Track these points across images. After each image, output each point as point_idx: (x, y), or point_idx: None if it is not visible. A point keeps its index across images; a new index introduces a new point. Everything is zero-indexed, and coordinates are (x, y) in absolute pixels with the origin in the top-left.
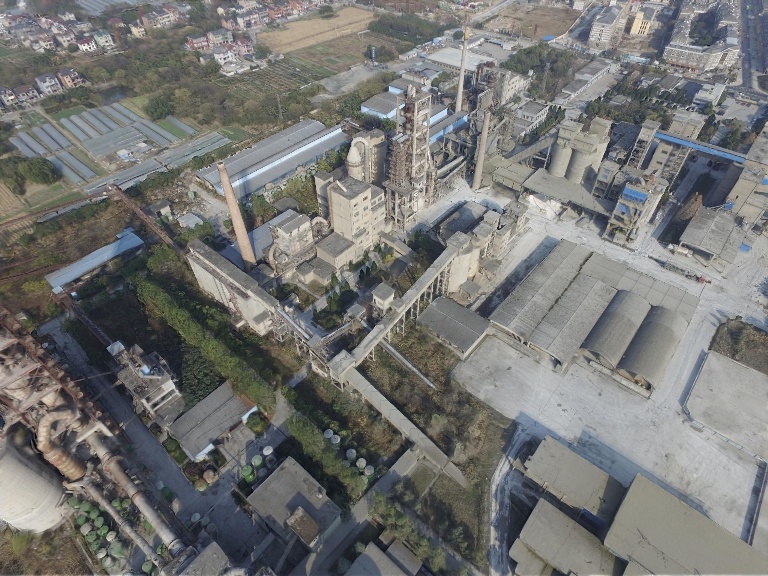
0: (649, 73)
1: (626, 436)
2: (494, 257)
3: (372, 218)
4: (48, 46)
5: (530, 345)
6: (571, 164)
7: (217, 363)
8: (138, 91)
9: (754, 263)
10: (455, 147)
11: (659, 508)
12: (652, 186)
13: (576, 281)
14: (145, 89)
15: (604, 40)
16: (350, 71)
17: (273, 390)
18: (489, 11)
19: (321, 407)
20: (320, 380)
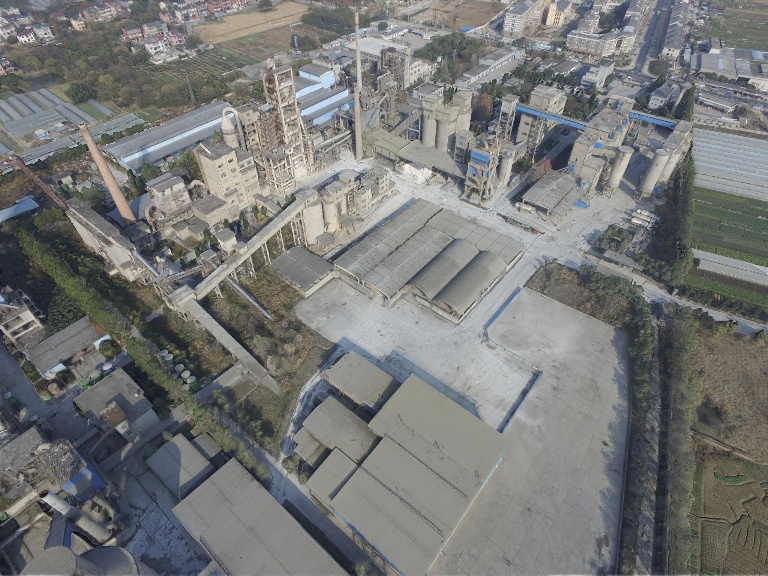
0: (549, 59)
1: (428, 354)
2: (359, 216)
3: (242, 180)
4: None
5: (365, 284)
6: (437, 134)
7: (76, 299)
8: (67, 78)
9: (589, 218)
10: (346, 123)
11: (421, 398)
12: (495, 149)
13: (419, 232)
14: (73, 76)
15: (516, 30)
16: (273, 59)
17: (131, 324)
18: (421, 5)
19: (169, 336)
20: (171, 314)
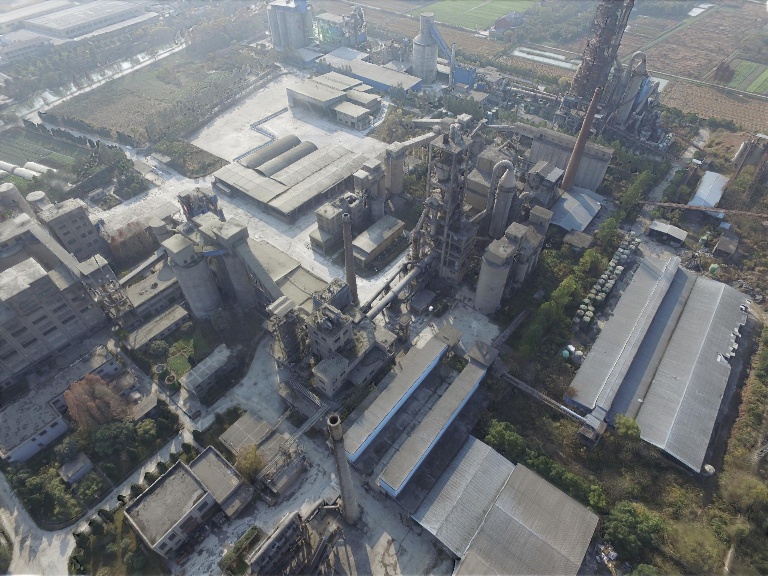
0: None
1: (312, 133)
2: None
3: None
4: None
5: None
6: None
7: None
8: None
9: None
10: None
11: (321, 96)
12: None
13: (298, 181)
14: None
15: None
16: None
17: None
18: None
19: None
20: None
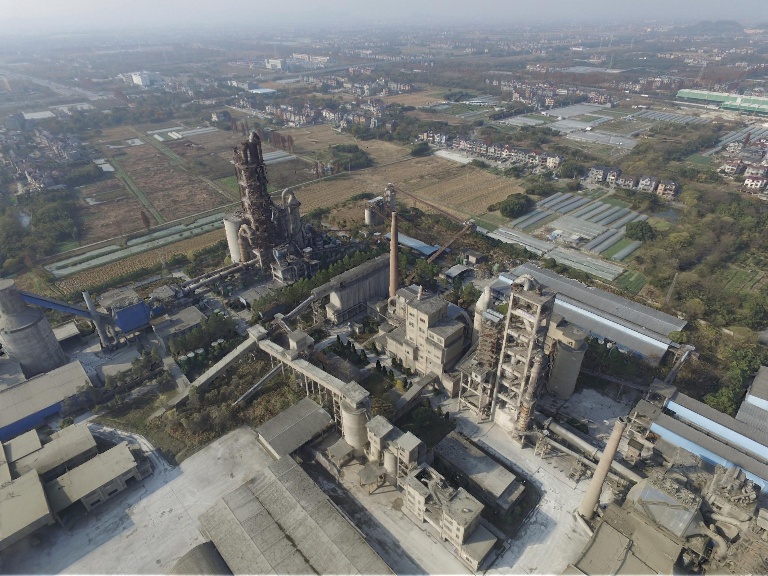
0: None
1: (102, 568)
2: None
3: None
4: (729, 170)
5: None
6: None
7: None
8: None
9: None
10: None
11: (15, 518)
12: None
13: None
14: (683, 221)
15: None
16: None
17: None
18: None
19: None
20: None
